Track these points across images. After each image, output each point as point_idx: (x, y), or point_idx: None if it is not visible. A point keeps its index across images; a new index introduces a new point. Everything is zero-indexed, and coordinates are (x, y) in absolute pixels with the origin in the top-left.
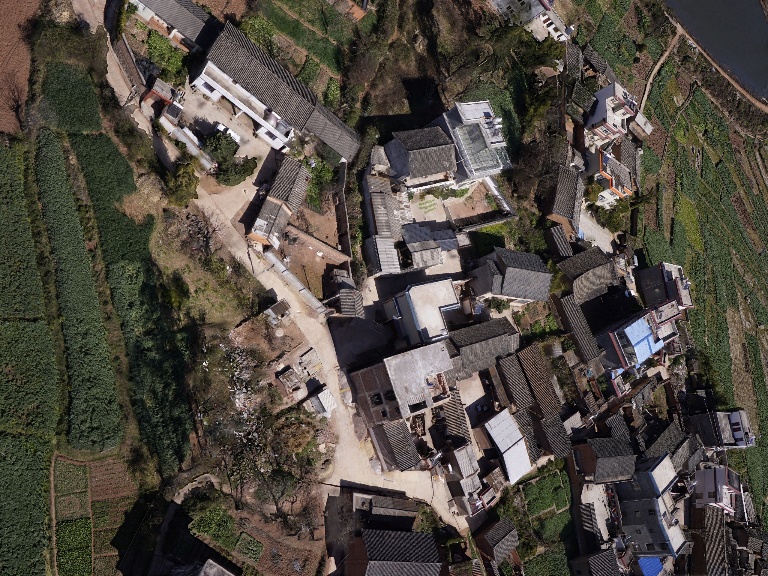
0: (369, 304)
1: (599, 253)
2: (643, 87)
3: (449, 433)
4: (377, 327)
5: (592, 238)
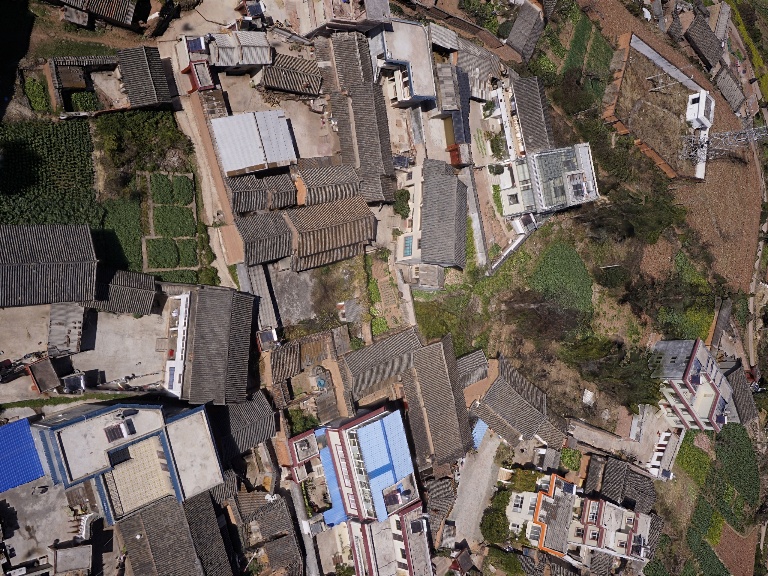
0: None
1: (468, 437)
2: None
3: (277, 53)
4: None
5: (468, 488)
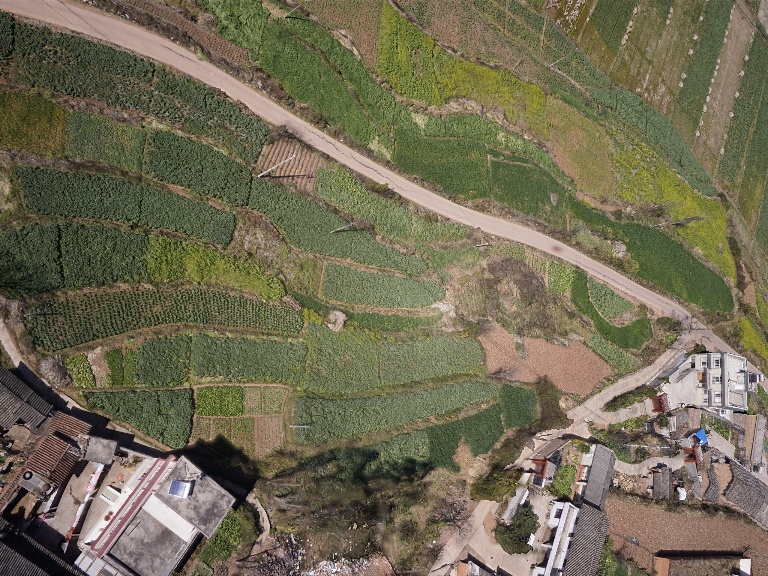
0: None
1: None
2: None
3: None
4: None
5: None
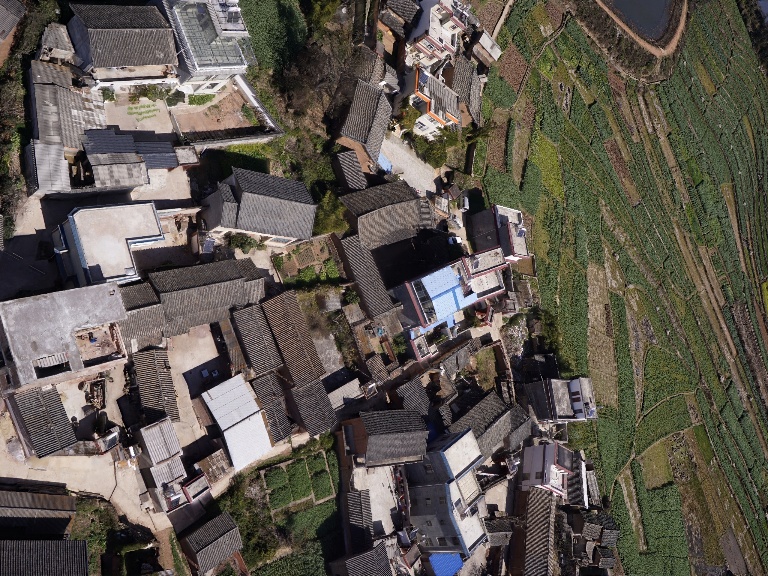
0: (28, 233)
1: (404, 188)
2: (500, 9)
3: (142, 405)
4: (38, 264)
5: (407, 173)
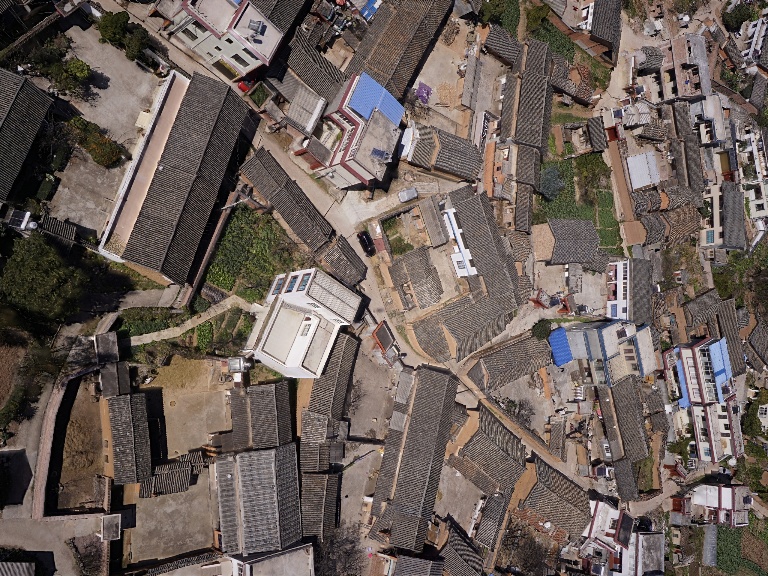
0: None
1: None
2: None
3: None
4: None
5: None
